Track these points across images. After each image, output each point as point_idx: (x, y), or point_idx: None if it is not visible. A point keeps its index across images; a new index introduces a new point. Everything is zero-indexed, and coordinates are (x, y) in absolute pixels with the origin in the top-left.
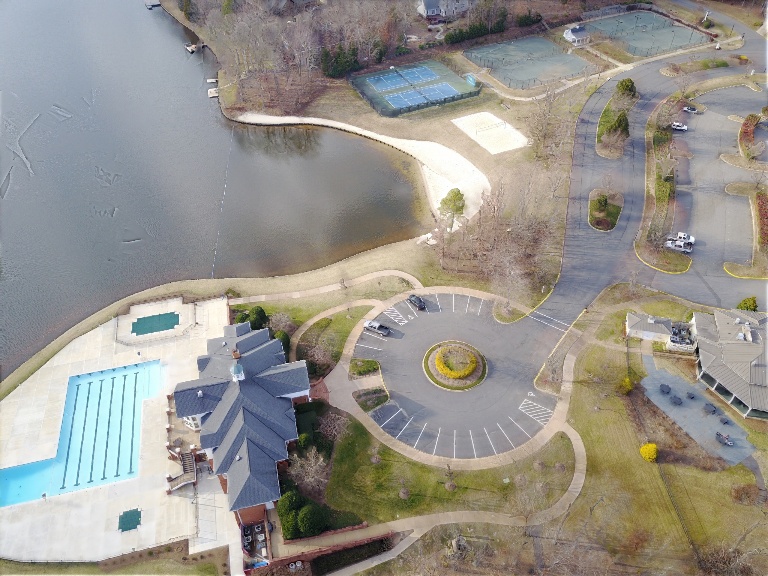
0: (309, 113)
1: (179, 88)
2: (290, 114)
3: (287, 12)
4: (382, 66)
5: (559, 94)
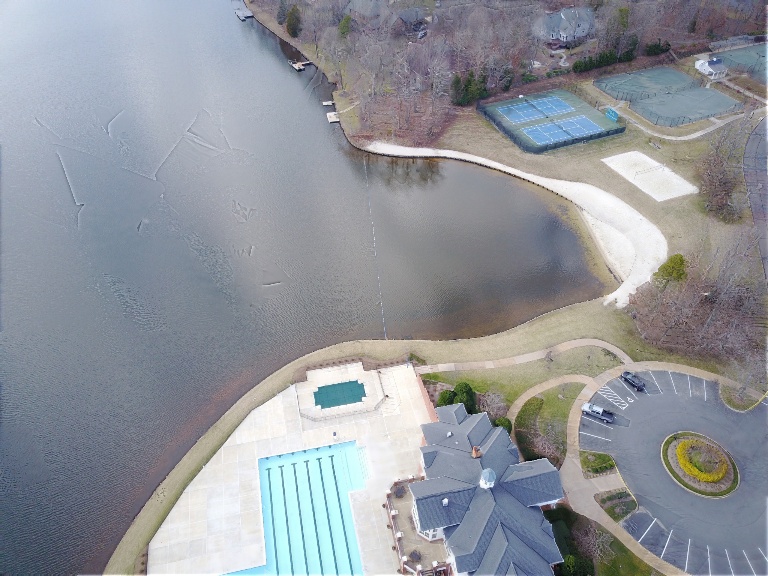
0: (443, 145)
1: (298, 111)
2: (423, 145)
3: (396, 30)
4: (510, 94)
5: (711, 134)
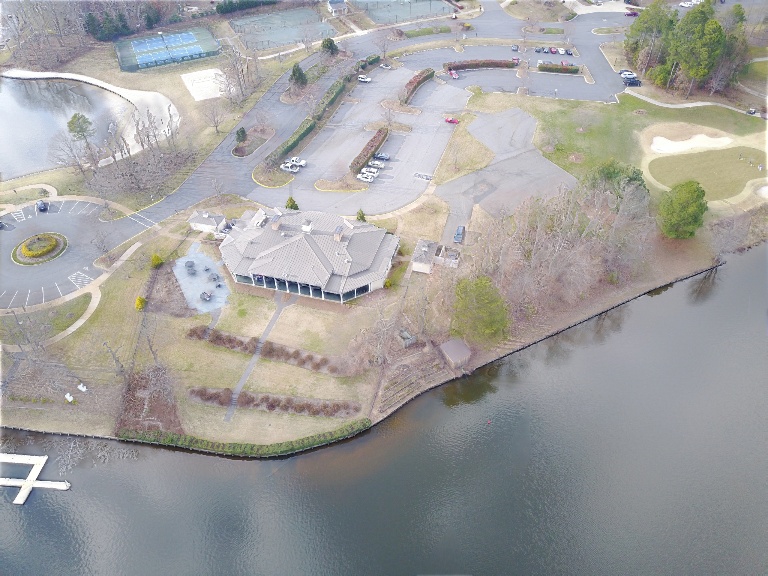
0: (66, 69)
1: None
2: (49, 70)
3: None
4: (152, 32)
5: (288, 54)
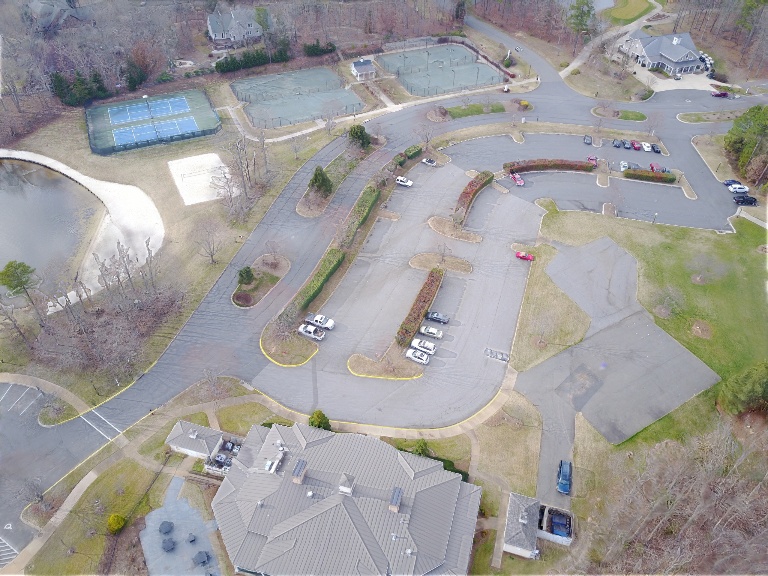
0: (22, 146)
1: None
2: (0, 146)
3: None
4: (135, 94)
5: (305, 136)
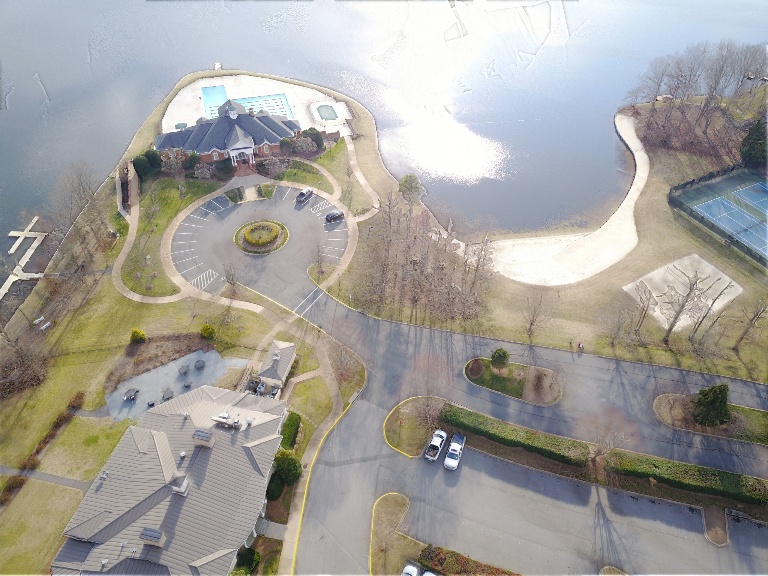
0: (654, 152)
1: None
2: (644, 141)
3: None
4: None
5: None
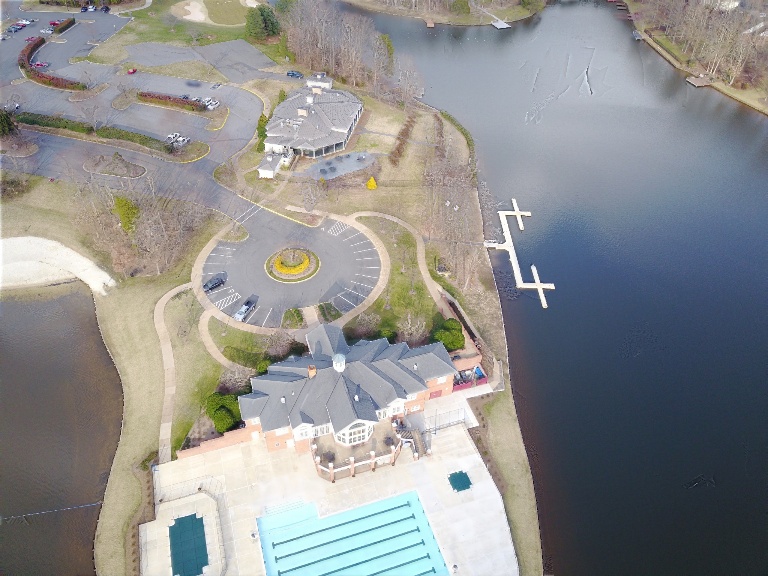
0: None
1: None
2: None
3: None
4: None
5: None
